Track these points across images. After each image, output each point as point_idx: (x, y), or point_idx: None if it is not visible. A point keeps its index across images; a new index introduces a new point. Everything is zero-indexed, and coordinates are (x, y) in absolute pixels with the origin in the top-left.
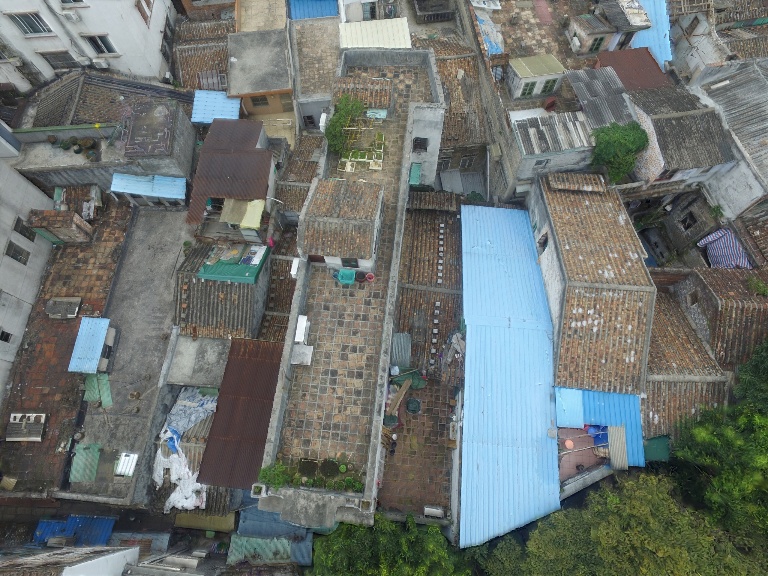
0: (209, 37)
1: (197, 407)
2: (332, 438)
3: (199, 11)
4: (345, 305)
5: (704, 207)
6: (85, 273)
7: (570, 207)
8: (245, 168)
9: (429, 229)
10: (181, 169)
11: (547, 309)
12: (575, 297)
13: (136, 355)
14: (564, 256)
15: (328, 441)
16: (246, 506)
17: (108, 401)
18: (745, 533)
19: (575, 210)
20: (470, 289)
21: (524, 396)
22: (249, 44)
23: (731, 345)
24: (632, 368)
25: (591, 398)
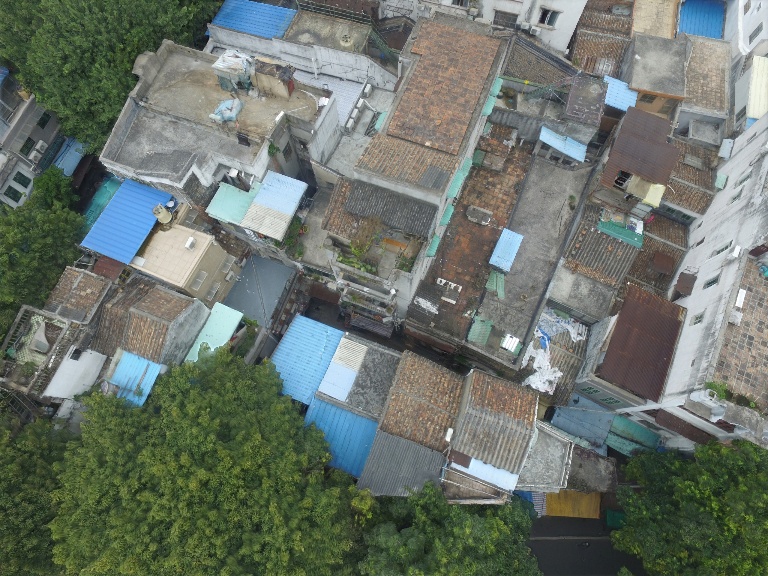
0: (604, 27)
1: (556, 322)
2: (745, 382)
3: (596, 1)
4: (765, 293)
5: None
6: (493, 194)
7: None
8: (654, 156)
9: None
10: None
11: None
12: None
13: (526, 268)
14: None
15: (741, 382)
16: None
17: (502, 294)
18: None
19: None
20: None
21: None
22: (653, 47)
23: None
24: None
25: None
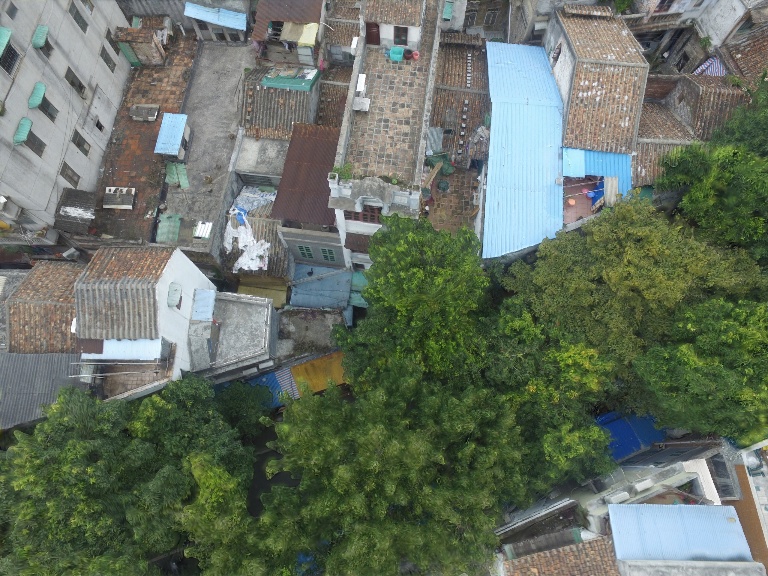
0: None
1: (258, 197)
2: (385, 163)
3: None
4: (395, 75)
5: (696, 42)
6: (160, 89)
7: (581, 25)
8: None
9: (458, 58)
10: (243, 3)
11: (559, 96)
12: (583, 71)
13: (207, 151)
14: (575, 47)
15: (382, 165)
16: (297, 282)
17: (185, 184)
18: (707, 243)
19: (585, 27)
20: (495, 84)
21: (537, 155)
22: None
23: (708, 124)
24: (626, 131)
25: (592, 156)
